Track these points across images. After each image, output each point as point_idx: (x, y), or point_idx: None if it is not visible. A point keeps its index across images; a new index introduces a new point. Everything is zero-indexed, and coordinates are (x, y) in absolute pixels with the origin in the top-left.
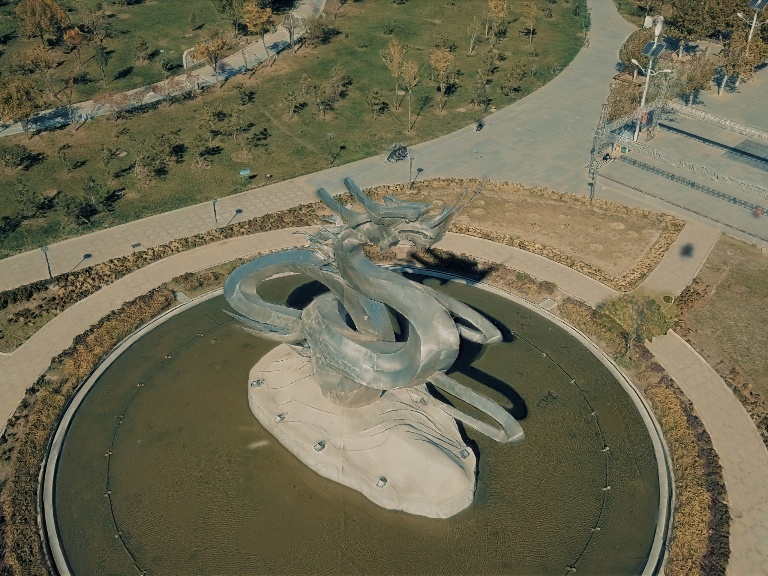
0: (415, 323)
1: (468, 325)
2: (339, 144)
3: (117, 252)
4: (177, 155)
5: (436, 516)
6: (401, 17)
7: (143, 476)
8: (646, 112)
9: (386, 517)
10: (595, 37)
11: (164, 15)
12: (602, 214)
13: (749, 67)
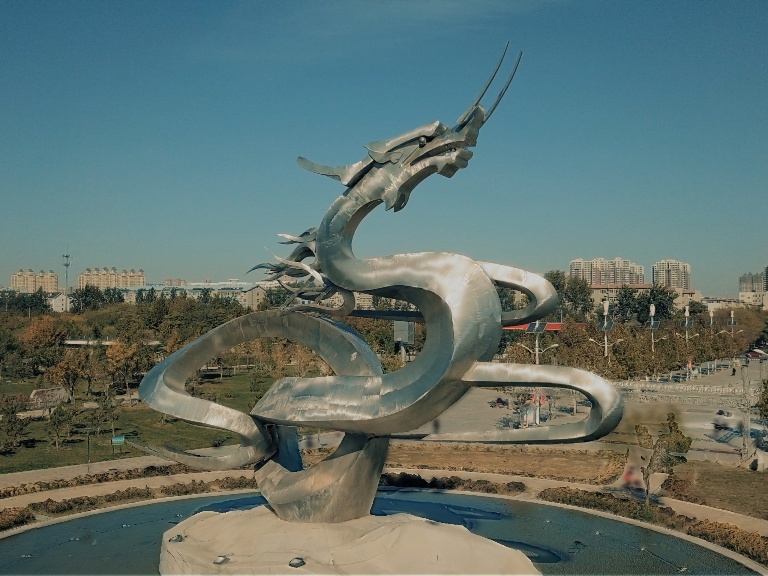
0: (440, 291)
1: (439, 514)
2: (224, 436)
3: None
4: (26, 444)
5: None
6: None
7: None
8: None
9: None
10: None
11: (4, 389)
12: (538, 455)
13: (616, 374)
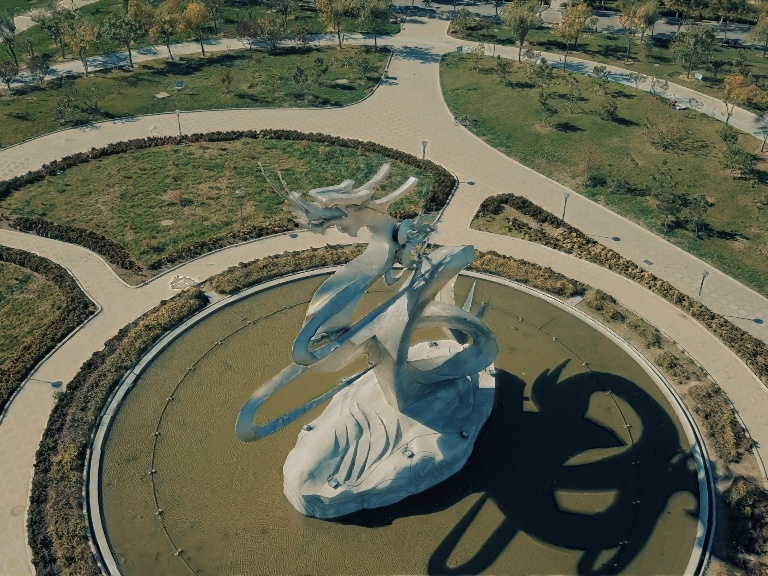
0: None
1: (604, 535)
2: None
3: (631, 253)
4: None
5: None
6: None
7: None
8: None
9: None
10: None
11: None
12: None
13: None
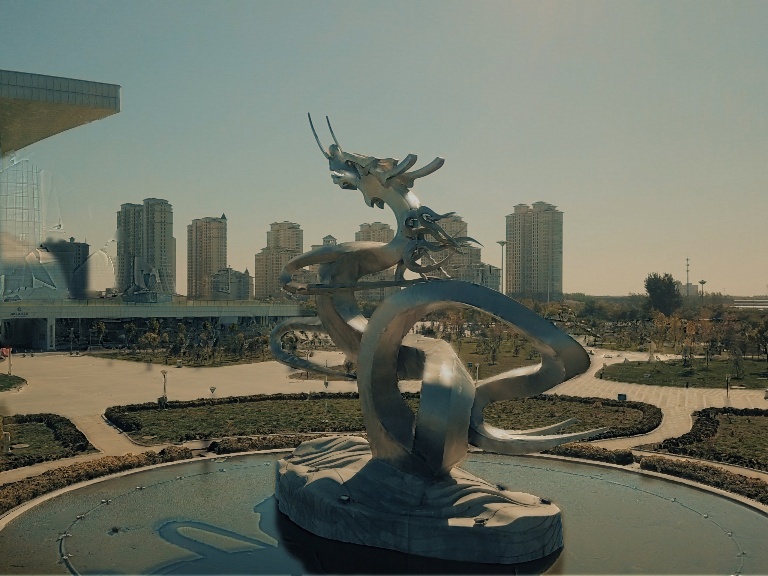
0: None
1: None
2: None
3: None
4: None
5: None
6: None
7: None
8: None
9: None
10: None
11: None
12: None
13: None
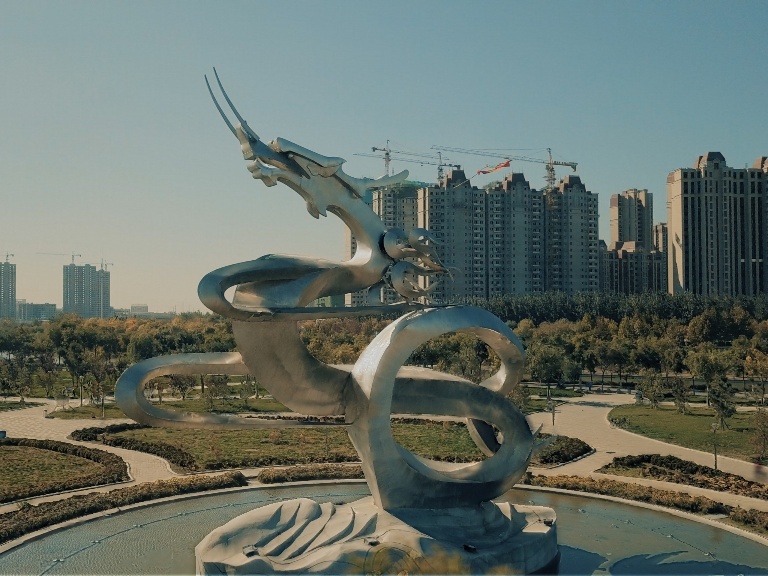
0: None
1: None
2: None
3: None
4: None
5: None
6: None
7: None
8: None
9: None
10: None
11: None
12: None
13: None
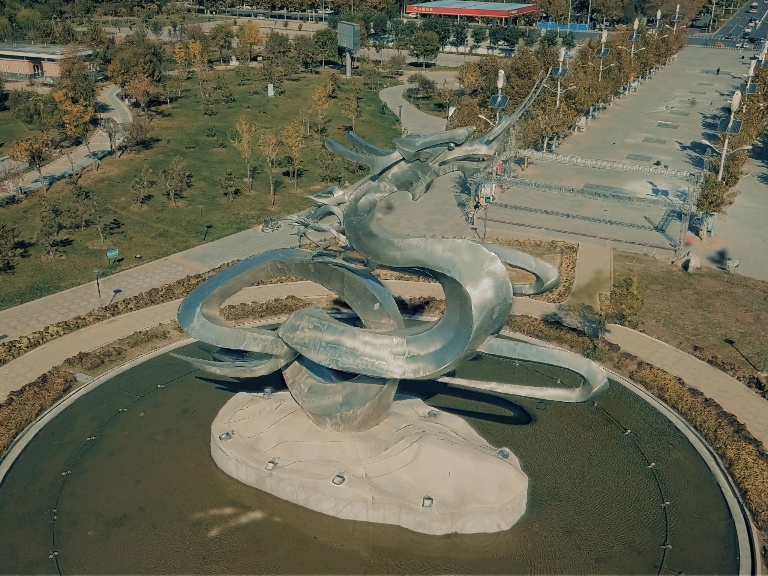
0: (461, 279)
1: None
2: (204, 224)
3: None
4: None
5: (497, 529)
6: (218, 124)
7: (109, 573)
8: (500, 163)
9: (435, 548)
10: (409, 127)
11: None
12: None
13: (567, 126)
